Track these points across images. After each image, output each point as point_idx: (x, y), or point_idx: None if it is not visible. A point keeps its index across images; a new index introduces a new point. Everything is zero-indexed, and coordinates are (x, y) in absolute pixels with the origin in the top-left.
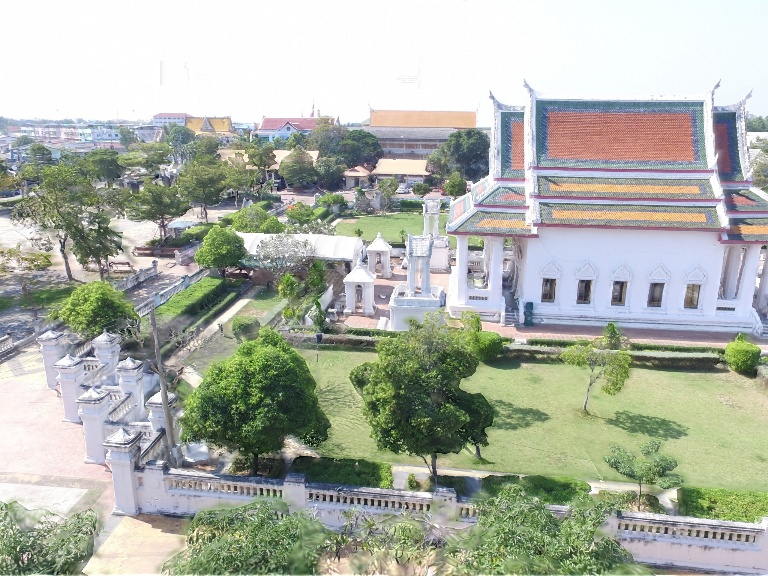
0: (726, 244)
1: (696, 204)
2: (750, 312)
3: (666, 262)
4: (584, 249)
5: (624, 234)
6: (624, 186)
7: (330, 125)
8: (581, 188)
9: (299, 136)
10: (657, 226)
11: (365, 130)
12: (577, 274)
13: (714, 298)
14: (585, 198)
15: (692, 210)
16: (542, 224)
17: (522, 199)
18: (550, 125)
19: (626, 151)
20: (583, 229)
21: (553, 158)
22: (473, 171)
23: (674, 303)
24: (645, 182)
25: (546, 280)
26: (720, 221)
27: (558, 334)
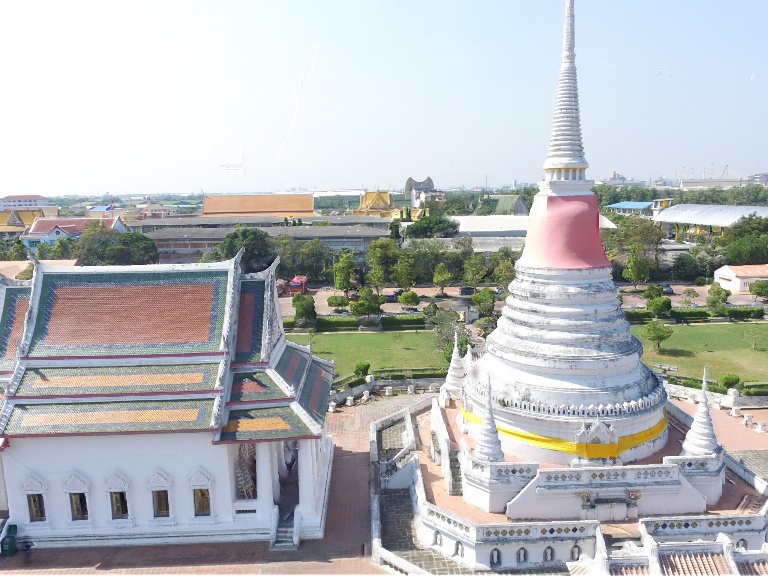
0: (220, 444)
1: (194, 396)
2: (269, 515)
3: (166, 466)
4: (69, 457)
5: (108, 439)
6: (121, 377)
7: (98, 229)
8: (70, 382)
9: (66, 241)
10: (137, 430)
11: (179, 221)
12: (64, 487)
13: (227, 502)
14: (69, 396)
15: (187, 405)
16: (4, 435)
17: (2, 399)
18: (56, 303)
19: (136, 332)
20: (54, 438)
21: (50, 345)
22: (252, 271)
23: (184, 511)
24: (148, 370)
25: (32, 496)
26: (211, 418)
27: (26, 570)
